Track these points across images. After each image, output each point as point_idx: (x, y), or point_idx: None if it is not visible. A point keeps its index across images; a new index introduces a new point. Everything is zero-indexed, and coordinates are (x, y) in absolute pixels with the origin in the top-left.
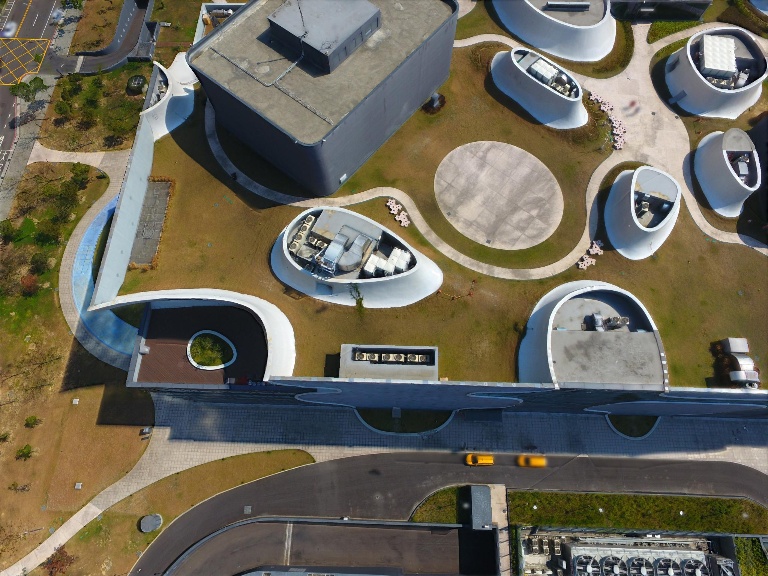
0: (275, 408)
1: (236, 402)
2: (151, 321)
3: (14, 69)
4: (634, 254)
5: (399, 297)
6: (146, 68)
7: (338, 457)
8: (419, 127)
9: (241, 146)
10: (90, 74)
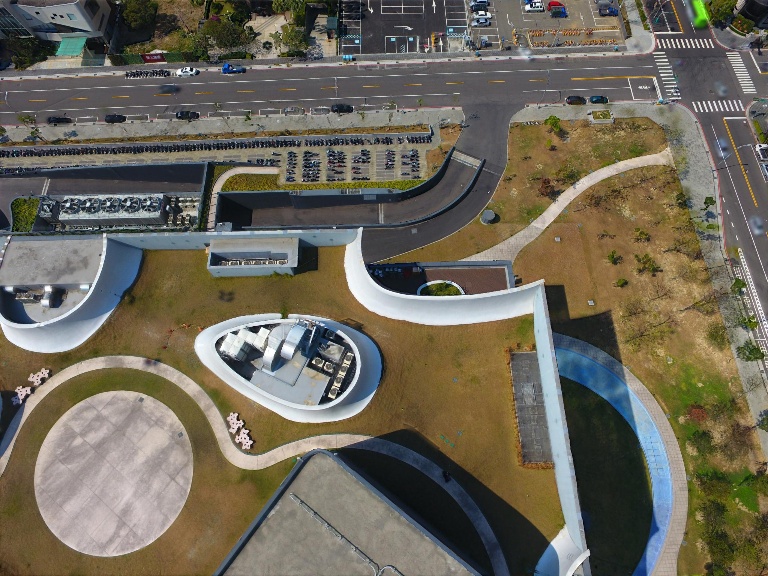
0: None
1: None
2: None
3: None
4: None
5: (243, 322)
6: None
7: None
8: None
9: (449, 531)
10: None
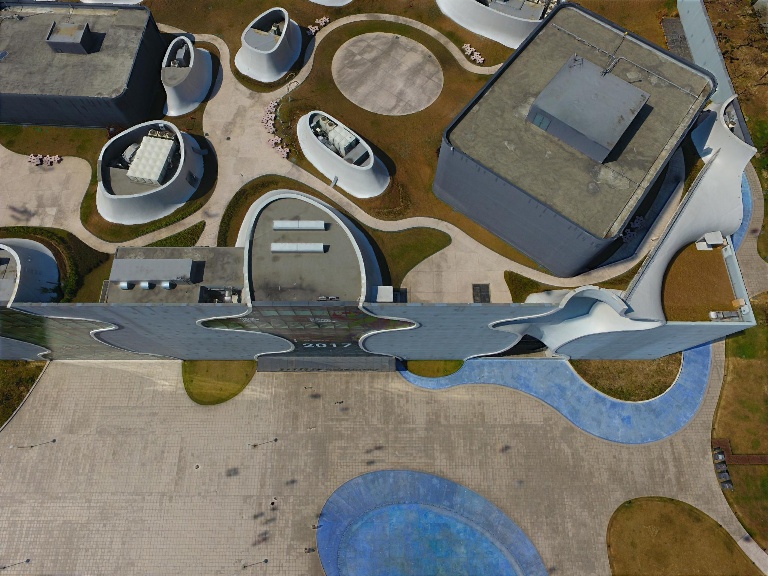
0: None
1: None
2: None
3: None
4: None
5: None
6: None
7: None
8: None
9: None
10: None
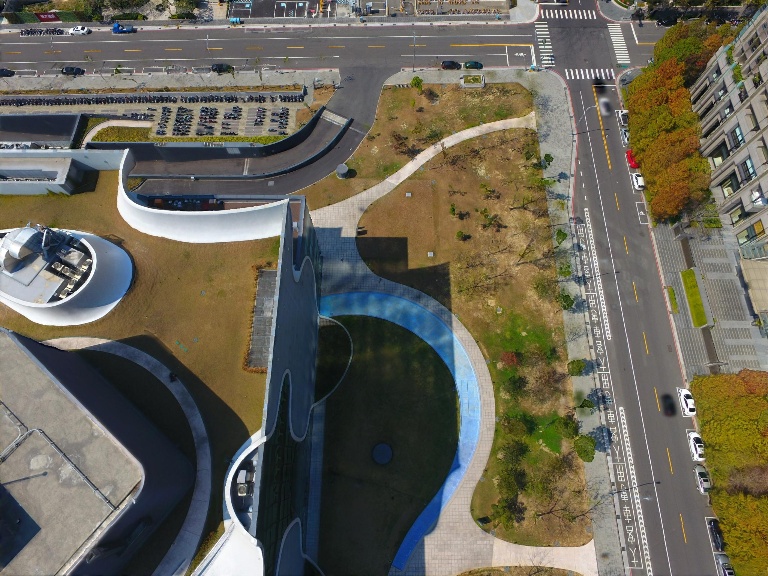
0: None
1: None
2: None
3: None
4: None
5: None
6: None
7: None
8: None
9: (164, 425)
10: None
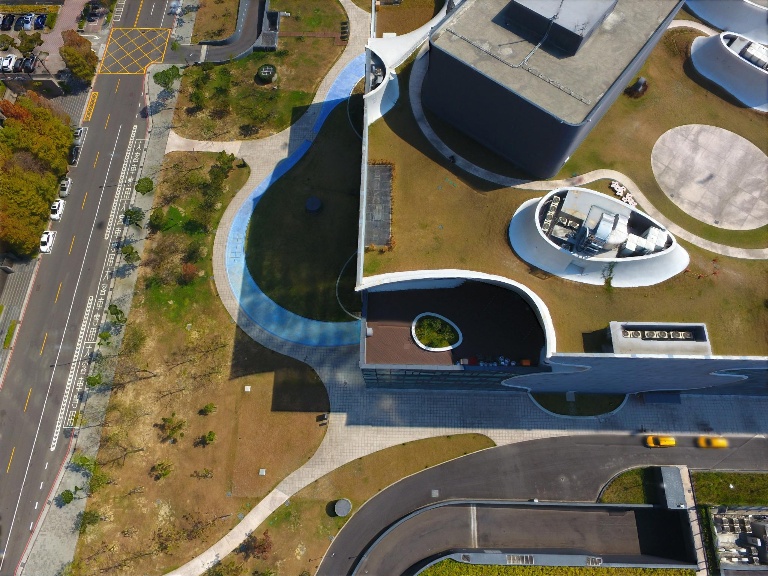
0: (449, 393)
1: (411, 387)
2: (369, 304)
3: (138, 58)
4: None
5: (648, 276)
6: (272, 57)
7: (518, 440)
8: (626, 111)
9: (452, 130)
10: (217, 63)
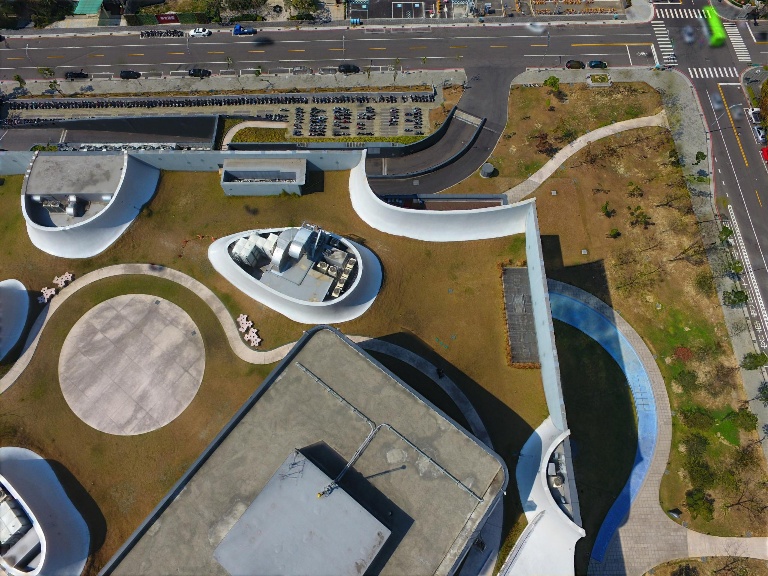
0: None
1: None
2: None
3: None
4: (10, 283)
5: None
6: None
7: None
8: None
9: None
10: None
